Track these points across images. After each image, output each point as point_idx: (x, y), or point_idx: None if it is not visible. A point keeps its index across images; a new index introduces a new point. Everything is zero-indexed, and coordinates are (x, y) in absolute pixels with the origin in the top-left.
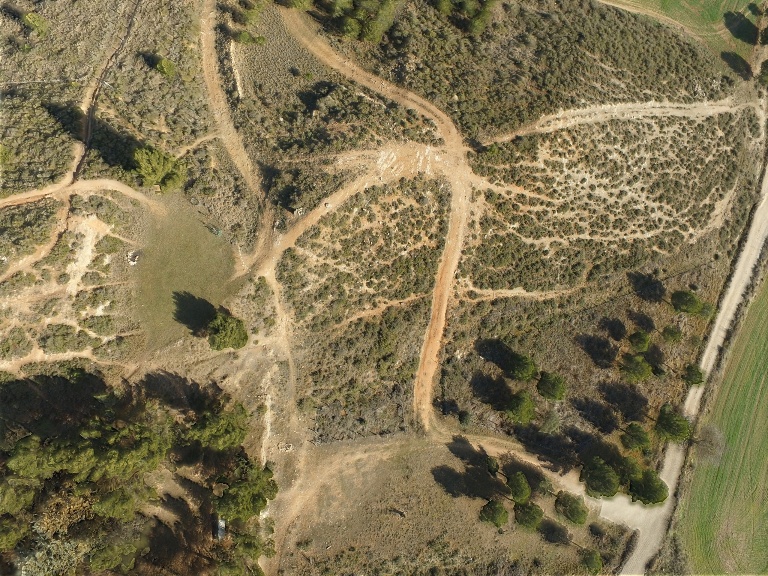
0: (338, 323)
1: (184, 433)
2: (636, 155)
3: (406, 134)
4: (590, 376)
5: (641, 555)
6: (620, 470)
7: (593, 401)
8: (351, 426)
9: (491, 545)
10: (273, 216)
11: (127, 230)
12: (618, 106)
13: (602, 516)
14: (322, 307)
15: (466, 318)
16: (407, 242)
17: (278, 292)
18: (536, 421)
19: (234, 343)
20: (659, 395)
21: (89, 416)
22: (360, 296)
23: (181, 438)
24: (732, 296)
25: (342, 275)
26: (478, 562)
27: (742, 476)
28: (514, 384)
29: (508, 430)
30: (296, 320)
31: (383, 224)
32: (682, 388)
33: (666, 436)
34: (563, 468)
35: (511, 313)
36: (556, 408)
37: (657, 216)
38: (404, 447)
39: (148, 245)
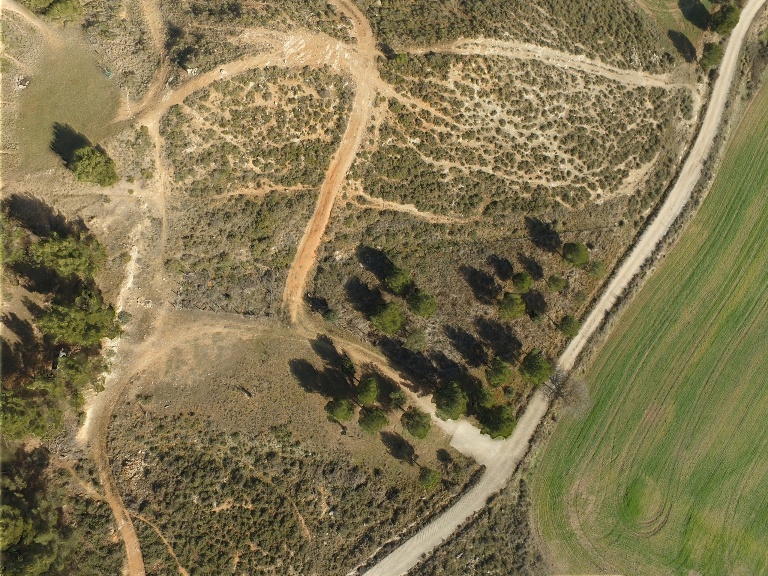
0: (218, 194)
1: (42, 260)
2: (555, 102)
3: (320, 25)
4: (468, 308)
5: (482, 490)
6: None
7: (466, 333)
8: (215, 299)
9: (334, 446)
10: (169, 72)
11: (23, 54)
12: (544, 49)
13: (451, 445)
14: (204, 173)
15: (351, 221)
16: (301, 130)
17: (160, 146)
18: (404, 339)
19: (100, 178)
20: (534, 343)
21: None
22: (244, 172)
23: (33, 259)
24: (630, 266)
25: (228, 145)
26: (316, 458)
27: (604, 442)
28: (389, 299)
29: (374, 341)
30: (175, 179)
31: (278, 105)
32: (560, 343)
33: (525, 376)
34: (422, 390)
35: (398, 228)
36: (427, 331)
37: (567, 168)
38: (266, 333)
39: (41, 73)
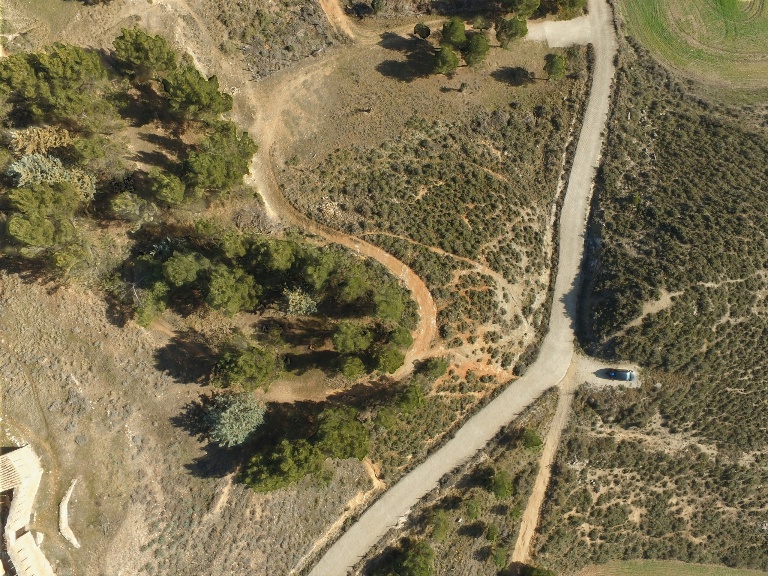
0: None
1: (127, 98)
2: None
3: None
4: None
5: (603, 61)
6: (546, 3)
7: None
8: (281, 56)
9: (464, 109)
10: None
11: None
12: None
13: (551, 47)
14: None
15: None
16: None
17: None
18: None
19: None
20: None
21: (31, 104)
22: None
23: (121, 87)
24: None
25: None
26: (459, 125)
27: None
28: None
29: (427, 10)
30: None
31: None
32: None
33: None
34: (494, 23)
35: None
36: None
37: None
38: (340, 59)
39: None
